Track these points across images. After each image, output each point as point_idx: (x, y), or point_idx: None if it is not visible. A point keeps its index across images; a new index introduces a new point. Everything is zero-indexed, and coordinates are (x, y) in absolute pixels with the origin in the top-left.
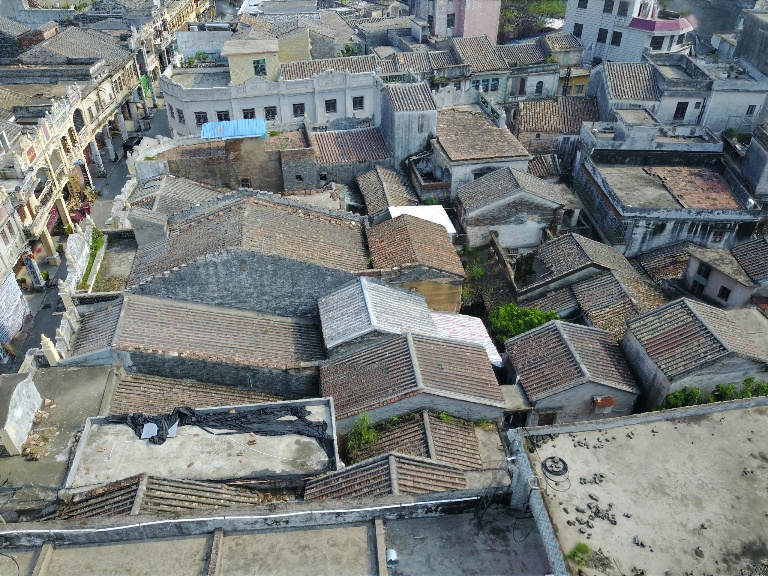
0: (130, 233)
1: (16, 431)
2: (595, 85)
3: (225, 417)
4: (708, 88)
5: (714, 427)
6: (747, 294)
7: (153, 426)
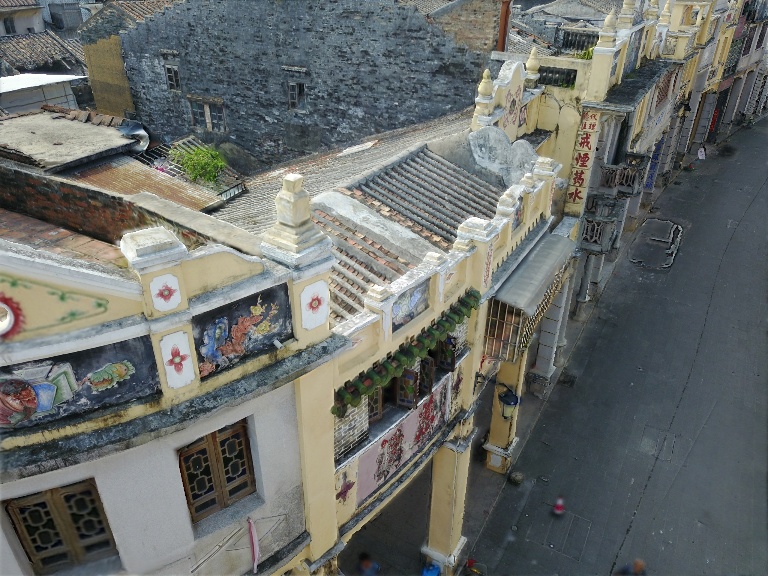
0: None
1: None
2: None
3: None
4: None
5: None
6: (41, 20)
7: None
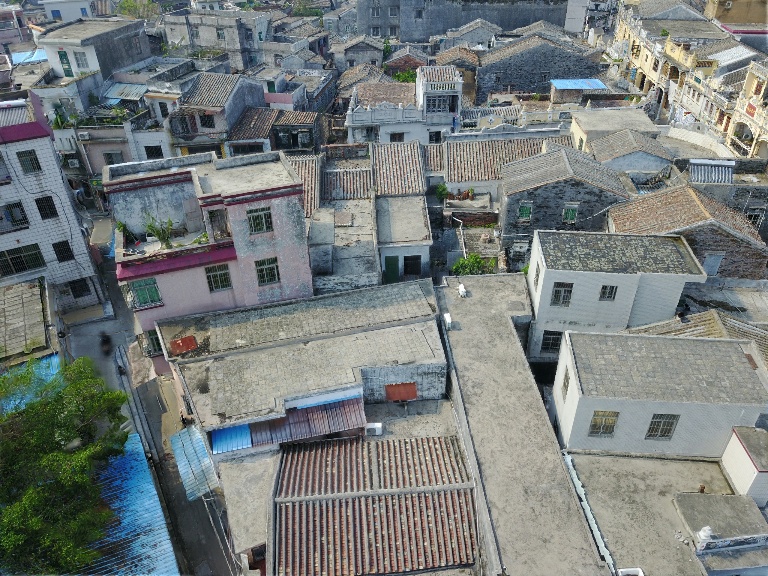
0: (605, 65)
1: None
2: (240, 103)
3: None
4: (194, 67)
5: None
6: None
7: None
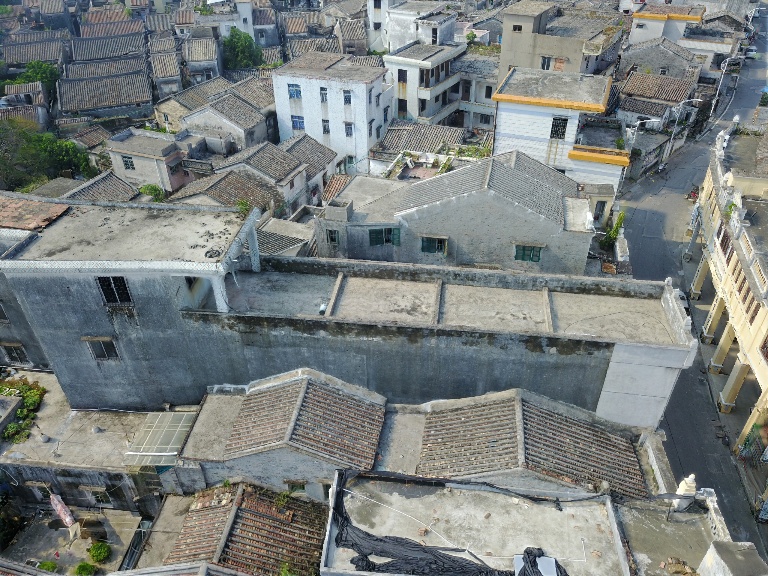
0: None
1: (710, 571)
2: None
3: (457, 572)
4: None
5: (93, 258)
6: None
7: (545, 573)
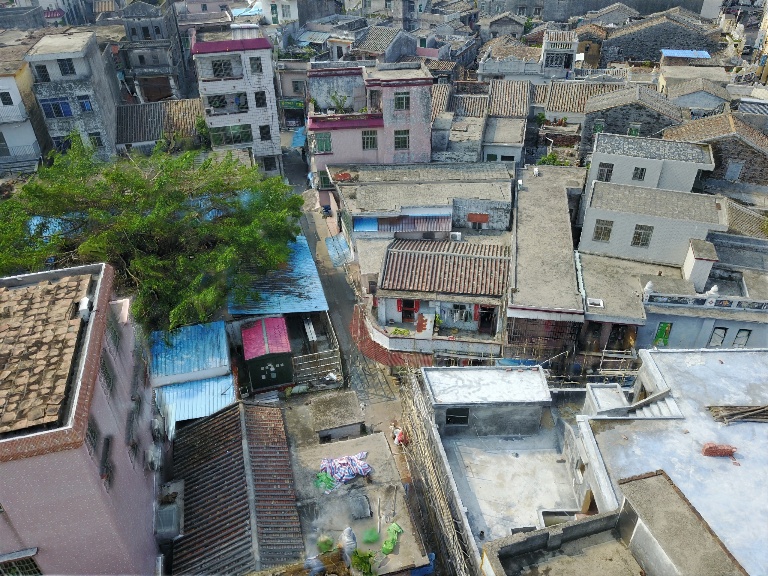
0: (723, 44)
1: None
2: (397, 51)
3: None
4: (366, 23)
5: None
6: None
7: None
